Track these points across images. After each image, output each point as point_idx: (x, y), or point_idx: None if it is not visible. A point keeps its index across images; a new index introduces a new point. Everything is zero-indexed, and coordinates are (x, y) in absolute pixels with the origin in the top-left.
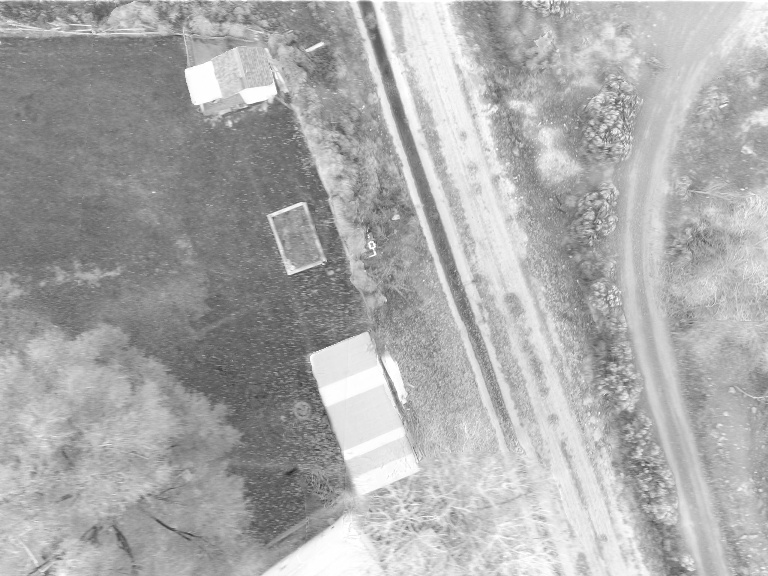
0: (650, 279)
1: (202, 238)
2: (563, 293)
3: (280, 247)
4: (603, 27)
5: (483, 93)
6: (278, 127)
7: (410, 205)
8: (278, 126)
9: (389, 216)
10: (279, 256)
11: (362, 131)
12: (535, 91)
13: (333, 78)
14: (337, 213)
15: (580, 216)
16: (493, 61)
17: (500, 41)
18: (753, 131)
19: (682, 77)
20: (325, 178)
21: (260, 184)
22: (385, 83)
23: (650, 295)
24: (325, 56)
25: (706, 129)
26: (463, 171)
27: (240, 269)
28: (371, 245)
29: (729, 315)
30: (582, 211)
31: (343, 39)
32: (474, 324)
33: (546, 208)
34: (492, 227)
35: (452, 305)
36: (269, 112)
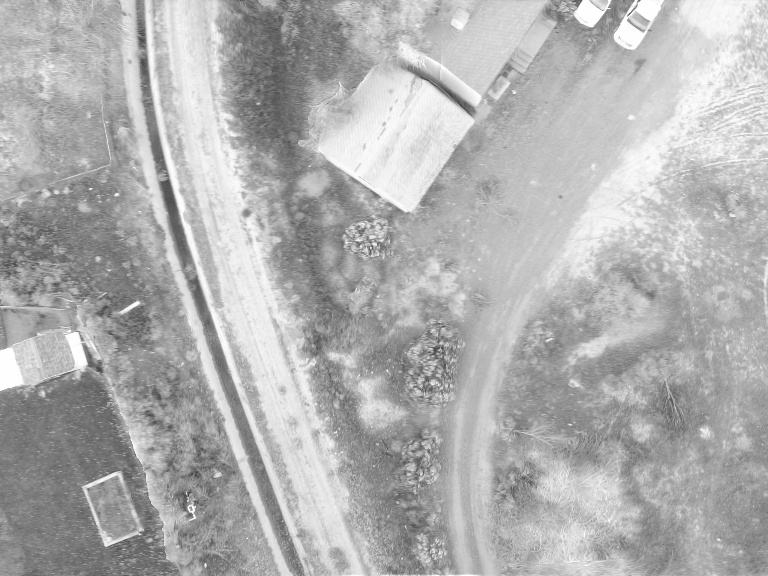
0: (479, 521)
1: (17, 512)
2: (387, 545)
3: (96, 519)
4: (428, 263)
5: (301, 346)
6: (92, 395)
7: (231, 463)
8: (92, 394)
9: (209, 476)
10: (96, 527)
11: (180, 390)
12: (354, 341)
13: (148, 340)
14: (148, 488)
15: (404, 464)
16: (315, 307)
17: (323, 284)
18: (580, 364)
19: (508, 312)
20: (136, 452)
21: (75, 455)
22: (207, 333)
23: (479, 537)
24: (141, 317)
25: (532, 365)
26: (283, 426)
27: (56, 542)
28: (190, 509)
29: (556, 559)
30: (406, 459)
31: (160, 297)
32: (303, 574)
33: (371, 456)
34: (314, 482)
35: (279, 558)
36: (82, 380)
